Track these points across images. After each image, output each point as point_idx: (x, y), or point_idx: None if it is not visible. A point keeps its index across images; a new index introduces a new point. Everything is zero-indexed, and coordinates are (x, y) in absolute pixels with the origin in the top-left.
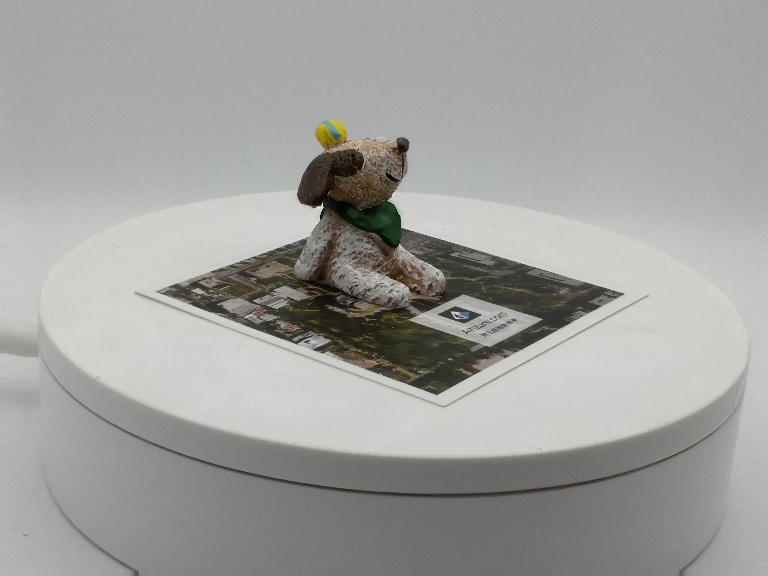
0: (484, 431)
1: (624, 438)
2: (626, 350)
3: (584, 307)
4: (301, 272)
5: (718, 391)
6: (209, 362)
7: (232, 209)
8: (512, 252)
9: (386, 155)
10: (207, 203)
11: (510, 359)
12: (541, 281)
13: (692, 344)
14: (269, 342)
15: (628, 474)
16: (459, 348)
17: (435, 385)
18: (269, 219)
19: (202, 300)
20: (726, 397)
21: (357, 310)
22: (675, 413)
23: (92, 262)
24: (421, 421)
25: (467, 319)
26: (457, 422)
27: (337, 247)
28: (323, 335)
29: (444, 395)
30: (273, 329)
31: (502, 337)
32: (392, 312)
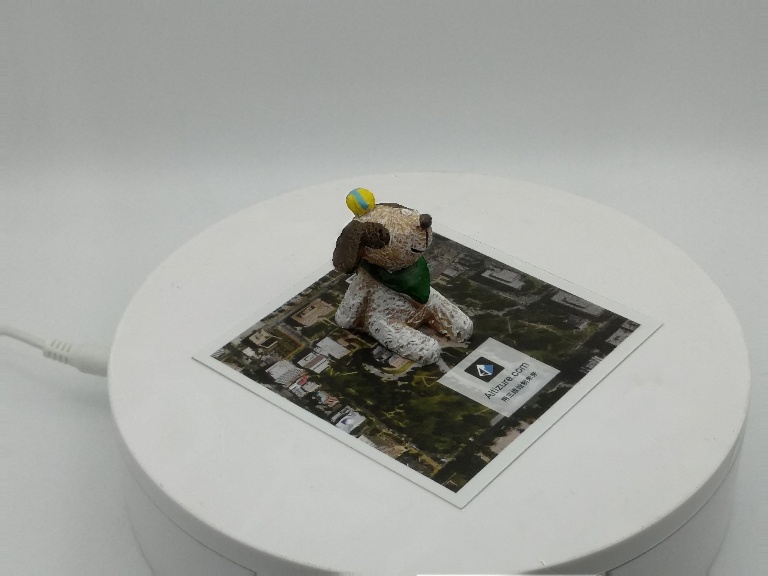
0: (495, 541)
1: (618, 542)
2: (633, 412)
3: (600, 349)
4: (341, 322)
5: (711, 468)
6: (257, 457)
7: (282, 215)
8: (541, 263)
9: (410, 233)
10: (259, 208)
11: (525, 435)
12: (564, 311)
13: (696, 398)
14: (310, 424)
15: (624, 565)
16: (480, 422)
17: (455, 479)
18: (316, 229)
19: (252, 366)
20: (718, 473)
21: (391, 370)
22: (668, 503)
23: (154, 312)
24: (440, 531)
25: (491, 376)
26: (472, 530)
27: (372, 302)
28: (359, 411)
29: (462, 492)
30: (314, 405)
31: (521, 402)
32: (423, 370)
